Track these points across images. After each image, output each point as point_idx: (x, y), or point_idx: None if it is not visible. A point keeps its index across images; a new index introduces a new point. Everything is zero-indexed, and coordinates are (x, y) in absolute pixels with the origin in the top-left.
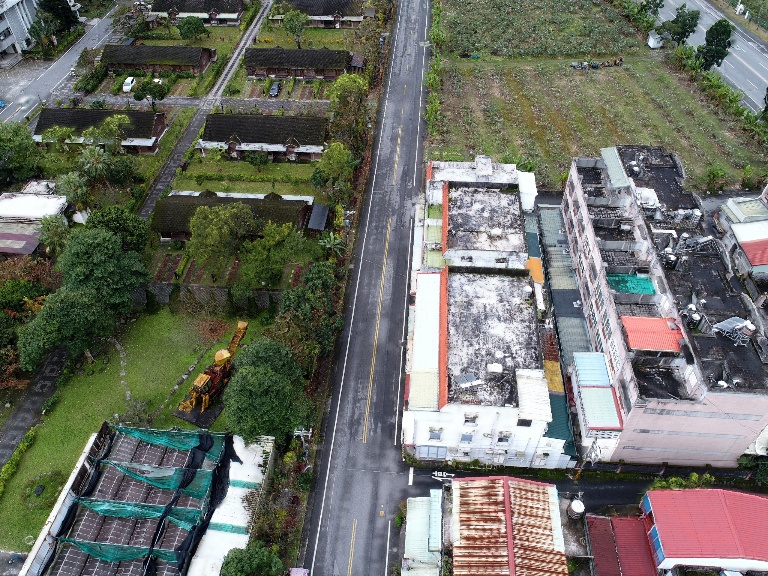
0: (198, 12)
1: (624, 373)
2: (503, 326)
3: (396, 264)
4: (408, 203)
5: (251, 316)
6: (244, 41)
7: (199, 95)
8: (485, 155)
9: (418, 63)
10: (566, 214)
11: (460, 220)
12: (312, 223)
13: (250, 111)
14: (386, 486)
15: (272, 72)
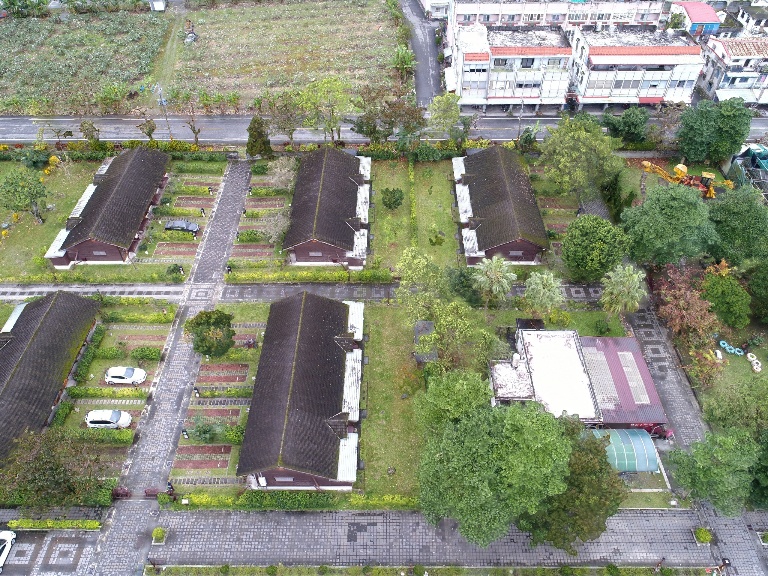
0: None
1: (641, 10)
2: (625, 38)
3: None
4: None
5: None
6: None
7: None
8: (459, 28)
9: None
10: None
11: None
12: None
13: None
14: None
15: None
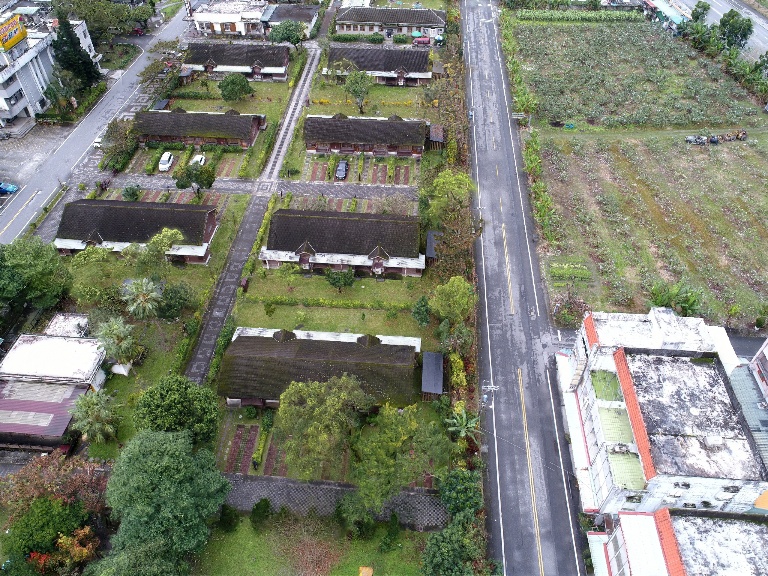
0: (239, 65)
1: None
2: None
3: (543, 446)
4: (537, 344)
5: (365, 538)
6: (295, 101)
7: (251, 176)
8: None
9: (505, 134)
10: (767, 383)
11: (657, 417)
12: (426, 383)
13: (321, 206)
14: None
15: (336, 147)
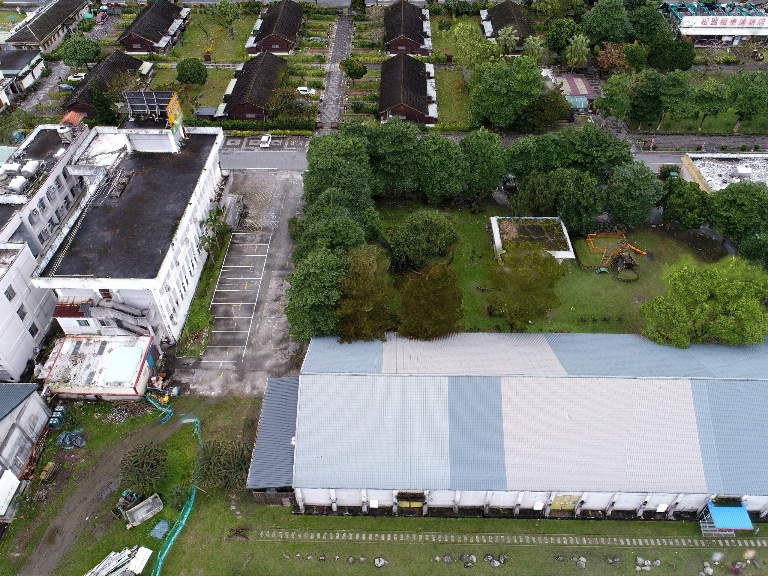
0: None
1: None
2: None
3: None
4: None
5: None
6: None
7: None
8: None
9: None
10: None
11: None
12: None
13: None
14: None
15: None
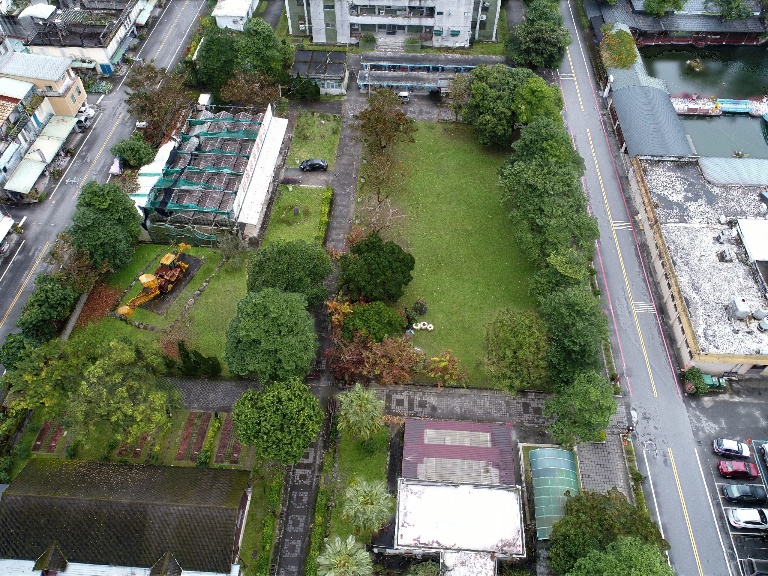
0: None
1: None
2: None
3: None
4: None
5: None
6: None
7: None
8: None
9: None
10: None
11: None
12: None
13: None
14: (44, 216)
15: None
